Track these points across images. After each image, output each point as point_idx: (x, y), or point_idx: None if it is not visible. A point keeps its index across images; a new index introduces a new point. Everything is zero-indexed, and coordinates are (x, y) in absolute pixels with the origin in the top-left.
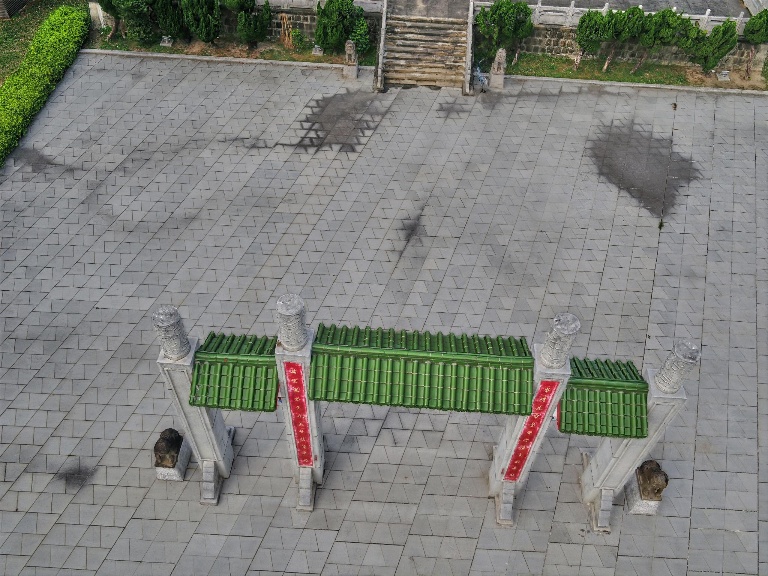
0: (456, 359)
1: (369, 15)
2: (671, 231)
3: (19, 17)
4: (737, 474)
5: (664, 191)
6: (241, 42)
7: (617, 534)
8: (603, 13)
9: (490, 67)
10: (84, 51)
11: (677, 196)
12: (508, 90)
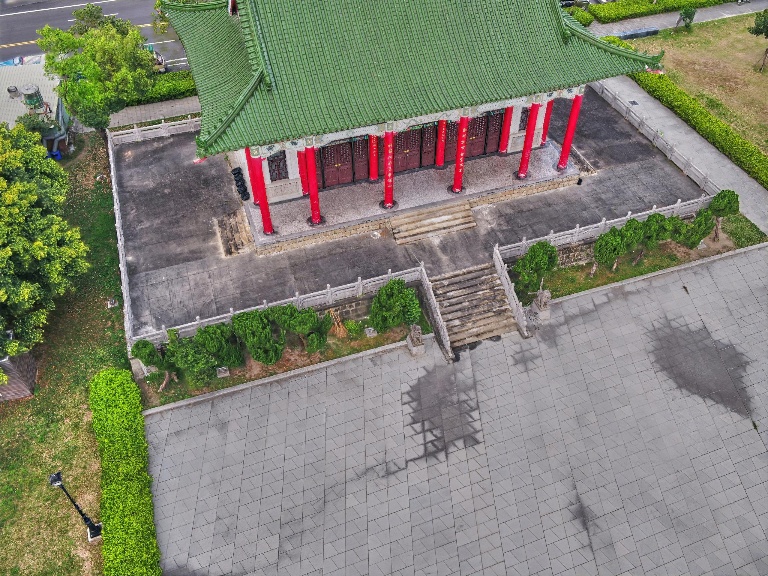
0: None
1: (409, 286)
2: (765, 429)
3: (41, 389)
4: None
5: (734, 387)
6: (293, 345)
7: None
8: (602, 226)
9: (526, 298)
10: (146, 414)
11: (746, 388)
12: (555, 319)
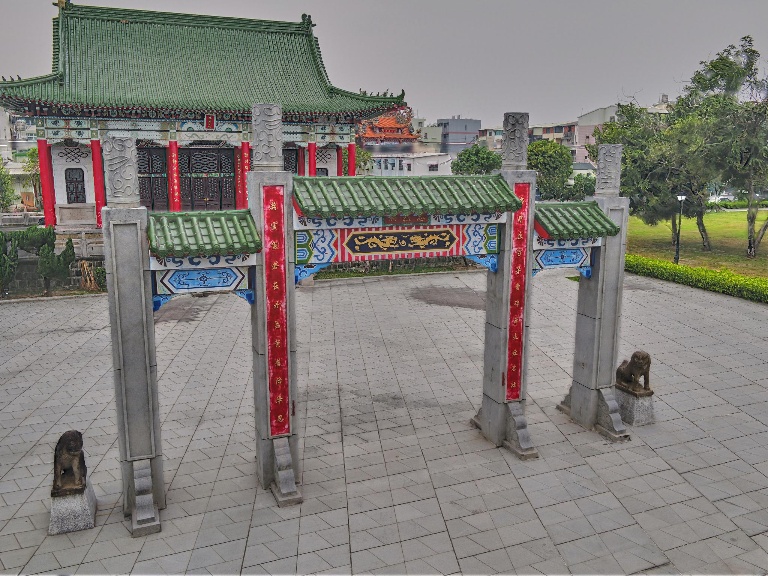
0: (433, 178)
1: None
2: None
3: None
4: (691, 391)
5: None
6: (36, 293)
7: (637, 439)
8: None
9: None
10: None
11: None
12: (319, 285)
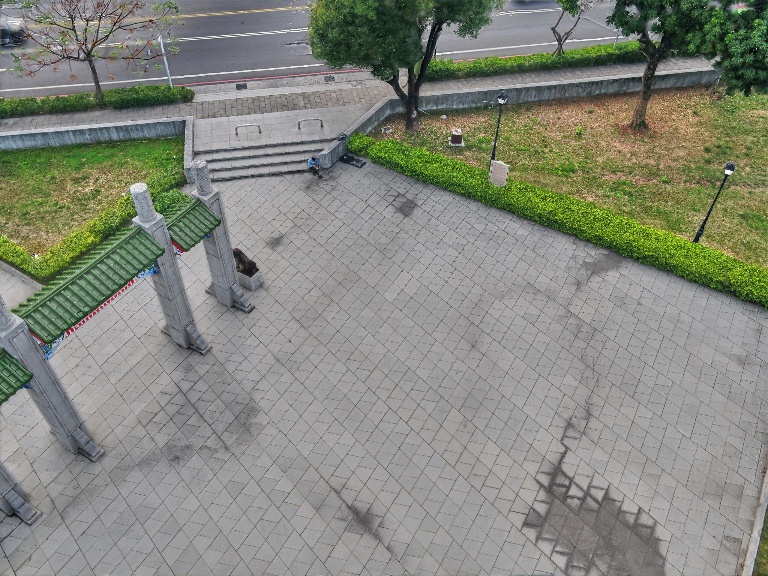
0: None
1: None
2: None
3: None
4: None
5: None
6: None
7: None
8: None
9: None
10: None
11: None
12: None
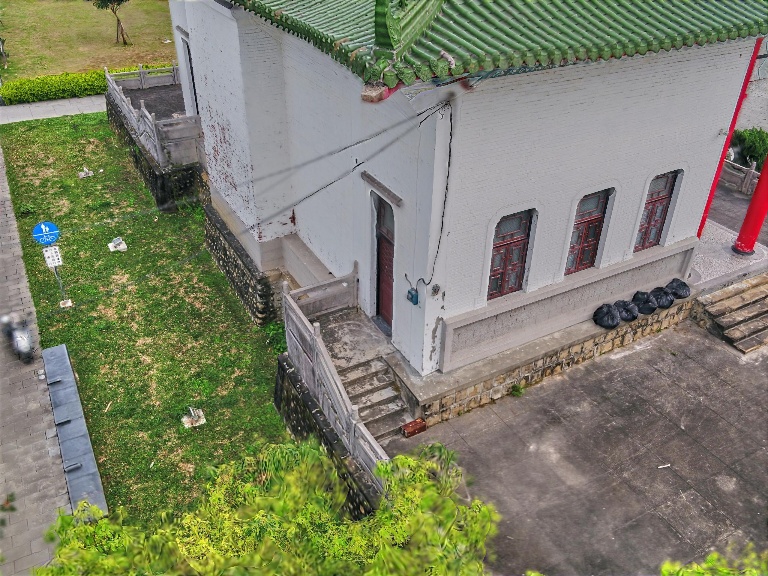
0: None
1: None
2: None
3: None
4: None
5: None
6: None
7: None
8: None
9: None
10: None
11: None
12: None
